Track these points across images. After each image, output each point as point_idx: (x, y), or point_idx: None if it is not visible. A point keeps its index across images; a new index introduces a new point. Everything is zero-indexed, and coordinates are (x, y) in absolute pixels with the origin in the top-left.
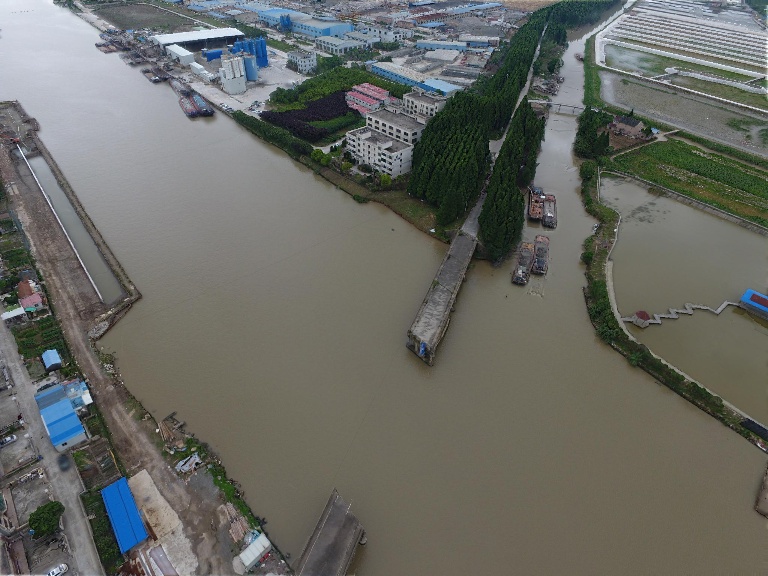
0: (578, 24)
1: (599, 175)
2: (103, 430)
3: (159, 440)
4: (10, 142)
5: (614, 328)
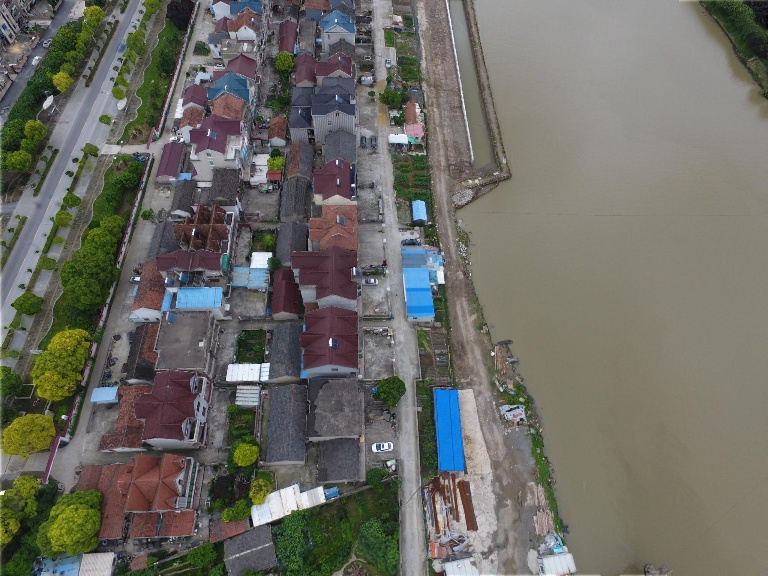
0: None
1: None
2: (445, 320)
3: (492, 365)
4: None
5: None
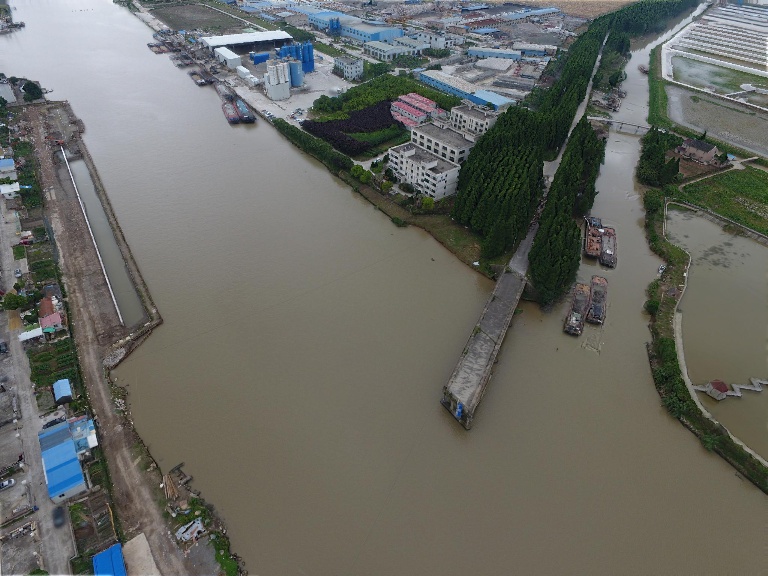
0: (643, 33)
1: (666, 207)
2: (105, 479)
3: (162, 497)
4: (55, 144)
5: (685, 400)
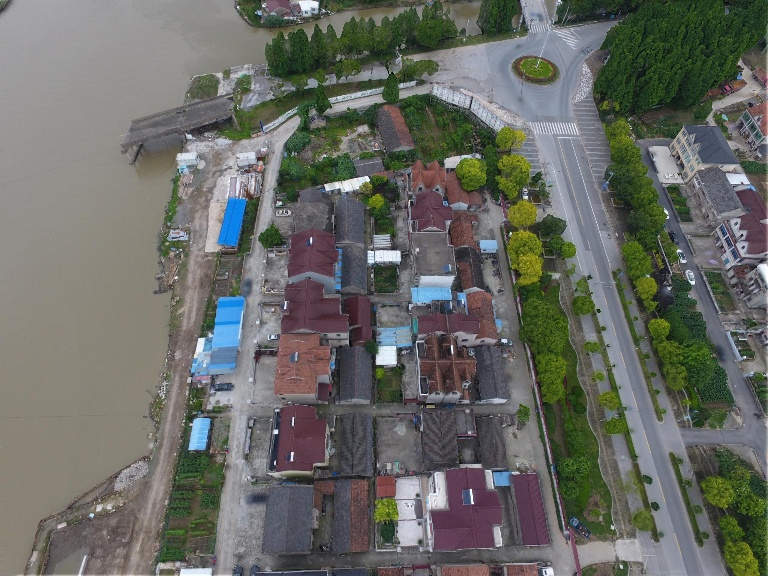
0: None
1: None
2: (210, 308)
3: (181, 269)
4: None
5: None
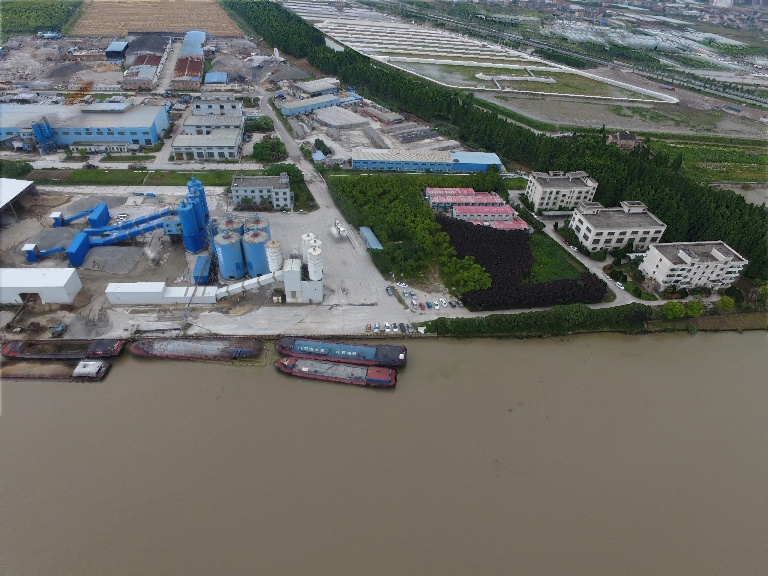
0: None
1: None
2: None
3: None
4: None
5: None
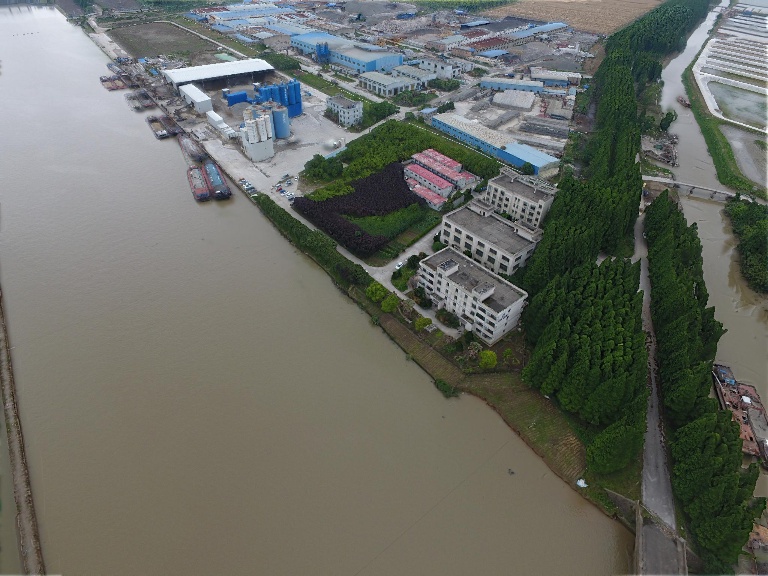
0: (666, 53)
1: None
2: None
3: None
4: None
5: None
